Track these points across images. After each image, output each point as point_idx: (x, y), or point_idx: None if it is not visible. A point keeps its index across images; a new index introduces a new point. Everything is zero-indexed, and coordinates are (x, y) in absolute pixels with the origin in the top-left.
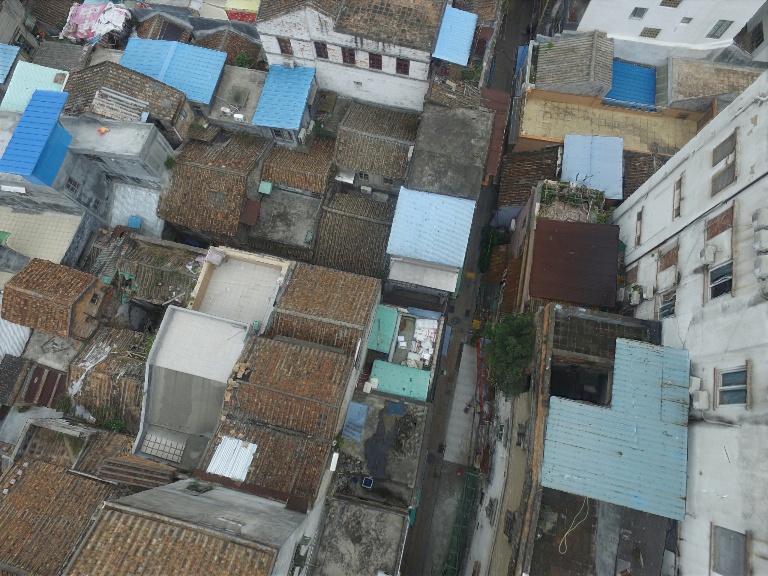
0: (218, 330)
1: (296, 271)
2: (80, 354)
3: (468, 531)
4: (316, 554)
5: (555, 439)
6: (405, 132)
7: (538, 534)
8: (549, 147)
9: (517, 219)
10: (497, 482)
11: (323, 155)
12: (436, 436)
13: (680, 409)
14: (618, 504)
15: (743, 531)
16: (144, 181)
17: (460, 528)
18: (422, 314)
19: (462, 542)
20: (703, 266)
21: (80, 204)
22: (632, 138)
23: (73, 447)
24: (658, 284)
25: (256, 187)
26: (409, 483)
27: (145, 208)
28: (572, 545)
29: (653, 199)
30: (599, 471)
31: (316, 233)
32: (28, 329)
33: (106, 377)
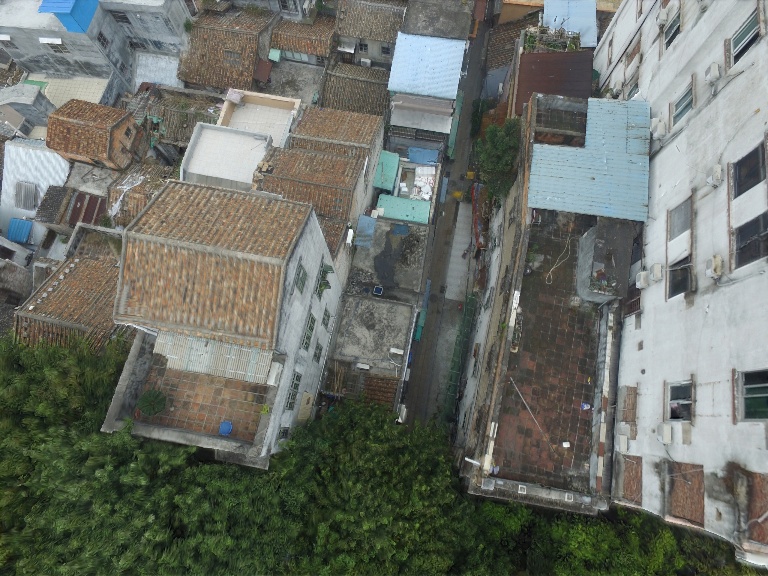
0: (242, 142)
1: (307, 111)
2: (117, 180)
3: (469, 341)
4: (335, 340)
5: (538, 173)
6: (400, 2)
7: (528, 270)
8: (531, 13)
9: (504, 83)
10: (493, 279)
11: (326, 26)
12: (437, 279)
13: (642, 143)
14: (592, 214)
15: (690, 192)
16: (165, 45)
17: (462, 335)
18: (421, 158)
19: (464, 351)
20: (659, 32)
21: (109, 61)
22: (606, 4)
23: (117, 249)
24: (626, 77)
25: (266, 53)
26: (415, 288)
27: (166, 75)
28: (557, 277)
29: (621, 21)
30: (576, 192)
31: (322, 96)
32: (68, 169)
33: (142, 196)
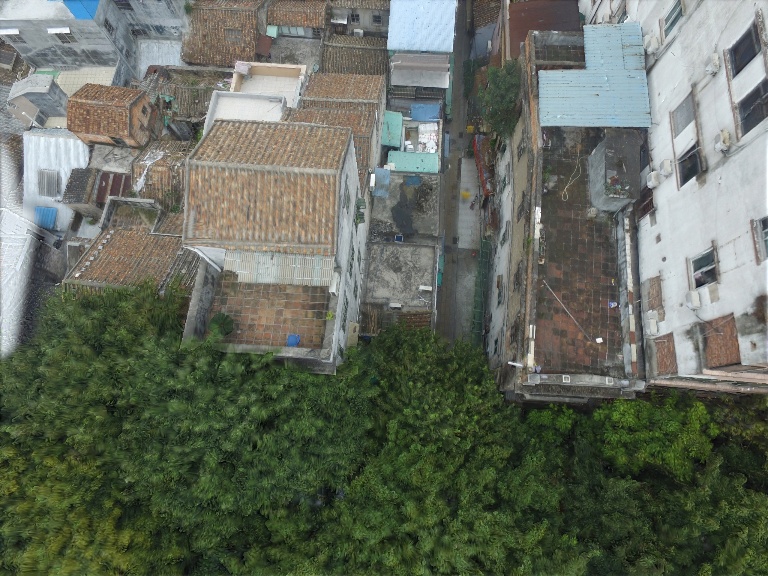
0: (258, 106)
1: (312, 77)
2: (139, 157)
3: (488, 281)
4: (366, 285)
5: (546, 96)
6: None
7: (544, 189)
8: None
9: (492, 40)
10: (507, 215)
11: (318, 0)
12: (449, 232)
13: (638, 59)
14: (600, 126)
15: (690, 88)
16: (167, 29)
17: (481, 275)
18: (423, 115)
19: (484, 291)
20: None
21: (116, 47)
22: None
23: (149, 218)
24: (612, 10)
25: (264, 29)
26: (434, 233)
27: (169, 59)
28: (572, 194)
29: None
30: (583, 108)
31: (321, 66)
32: (87, 153)
33: (165, 169)
